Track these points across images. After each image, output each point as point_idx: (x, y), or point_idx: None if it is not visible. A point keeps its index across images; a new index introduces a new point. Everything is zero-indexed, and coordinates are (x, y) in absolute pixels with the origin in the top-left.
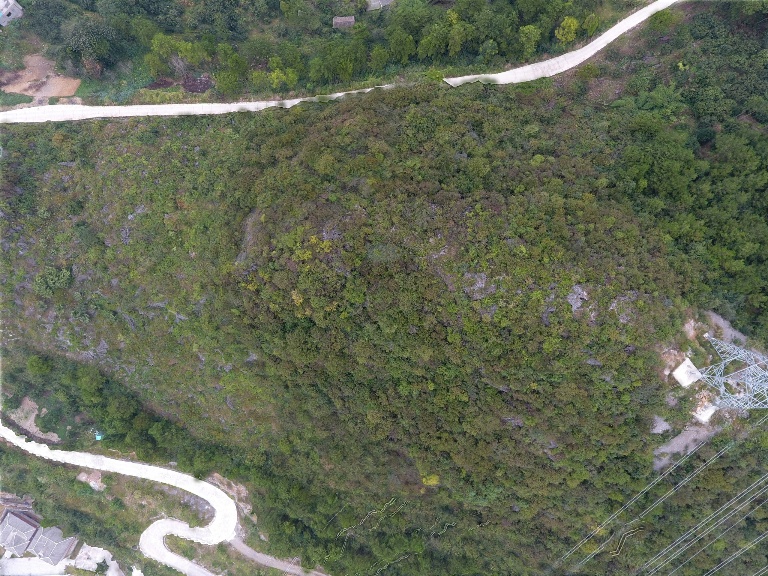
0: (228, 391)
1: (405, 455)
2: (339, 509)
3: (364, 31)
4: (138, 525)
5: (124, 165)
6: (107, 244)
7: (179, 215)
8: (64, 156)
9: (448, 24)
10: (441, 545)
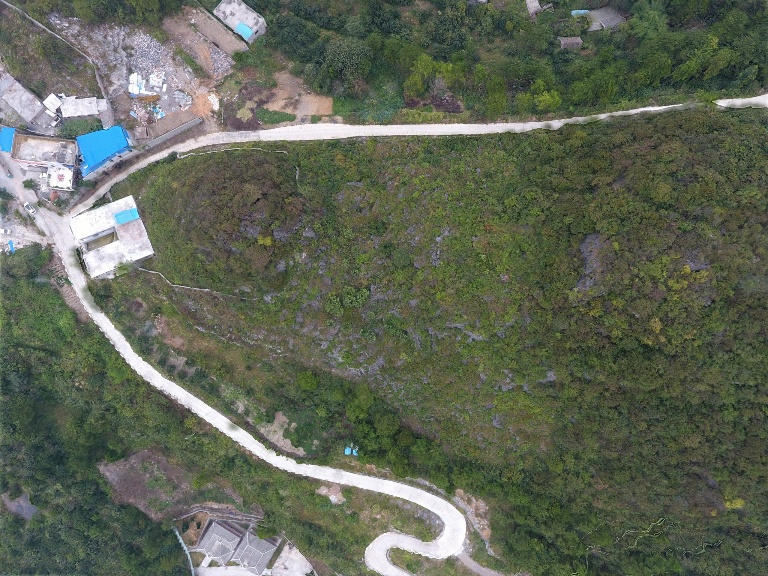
0: (500, 410)
1: (708, 478)
2: (594, 527)
3: (600, 53)
4: (367, 538)
5: (421, 187)
6: (416, 266)
7: (489, 238)
8: (351, 176)
9: (711, 49)
10: (694, 565)
